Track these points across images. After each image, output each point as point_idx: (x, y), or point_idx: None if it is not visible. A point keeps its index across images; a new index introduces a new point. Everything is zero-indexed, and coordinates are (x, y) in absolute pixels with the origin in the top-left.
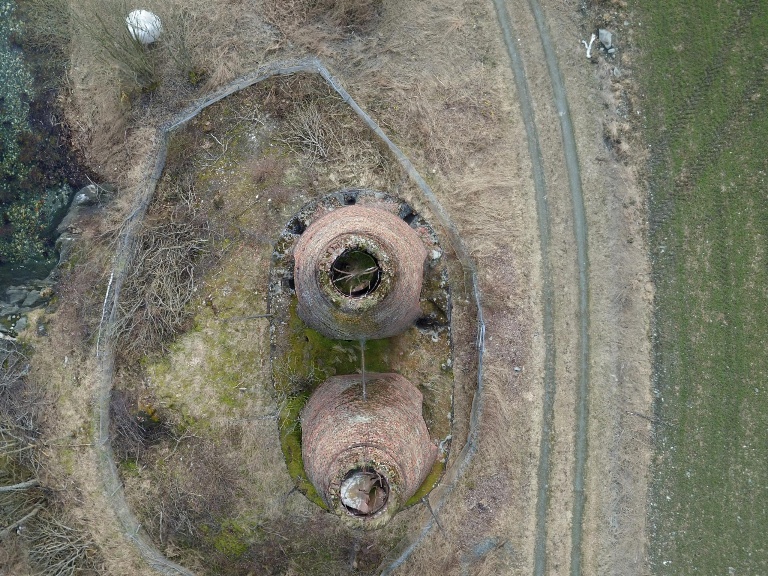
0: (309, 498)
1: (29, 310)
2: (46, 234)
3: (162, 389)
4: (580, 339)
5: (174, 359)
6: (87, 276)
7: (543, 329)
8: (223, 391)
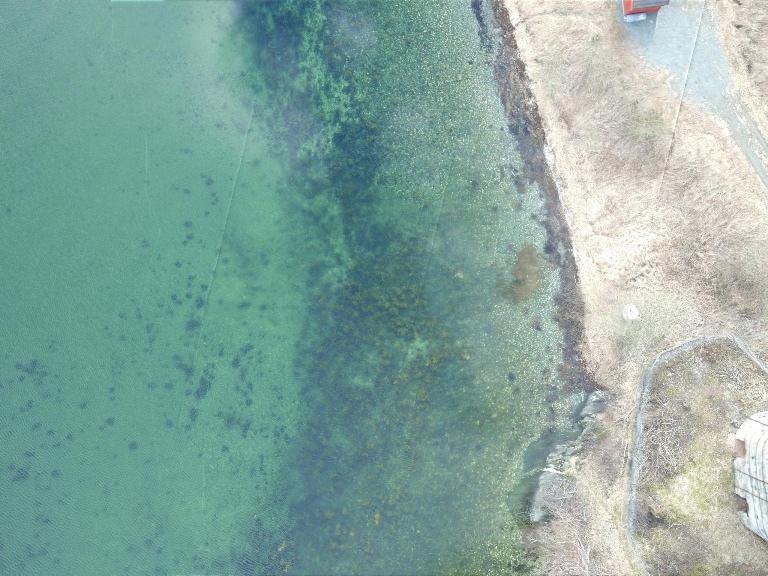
0: None
1: (570, 458)
2: (573, 417)
3: (668, 502)
4: None
5: (672, 487)
6: (615, 444)
7: None
8: (699, 502)
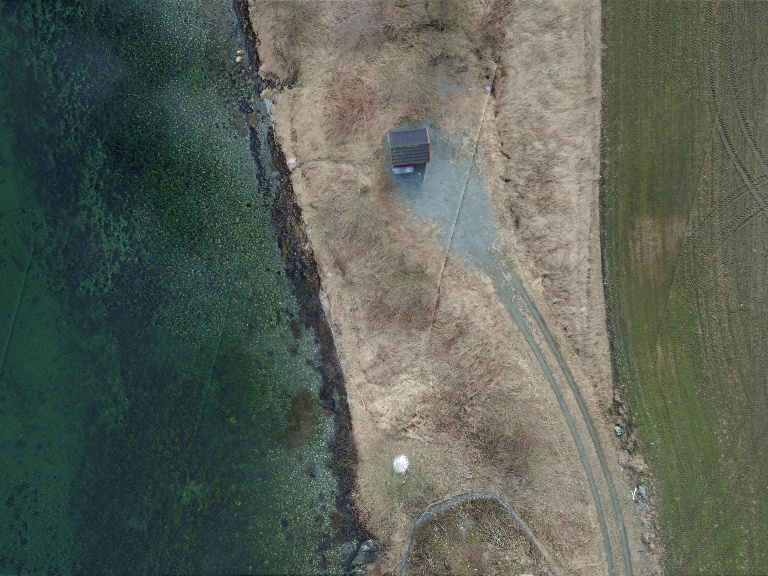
0: None
1: None
2: (345, 565)
3: None
4: None
5: None
6: None
7: None
8: None
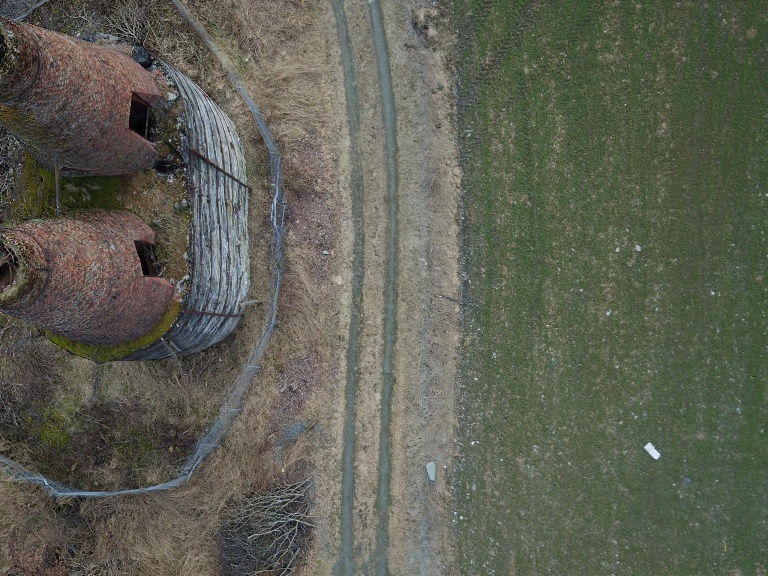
0: None
1: None
2: None
3: None
4: (389, 223)
5: None
6: None
7: (352, 214)
8: None
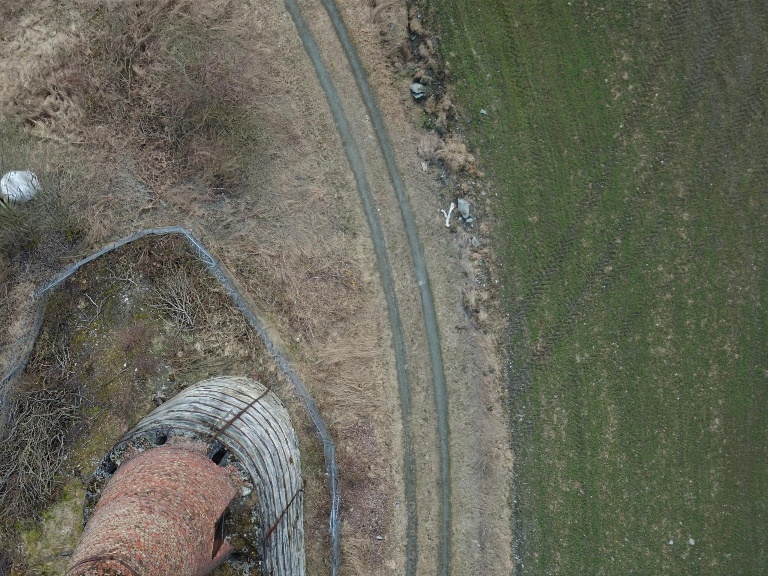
0: None
1: None
2: None
3: (34, 557)
4: (442, 506)
5: (45, 527)
6: None
7: (405, 497)
8: None
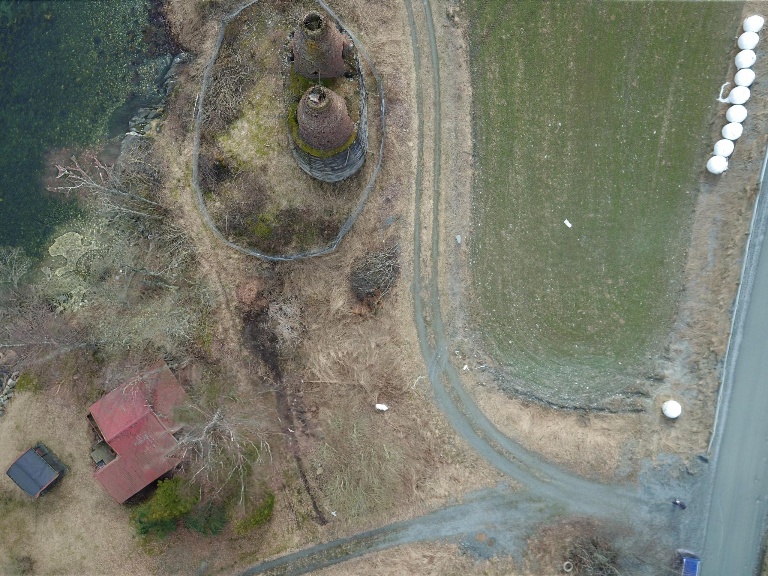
0: (301, 148)
1: (151, 120)
2: (159, 81)
3: (227, 147)
4: (436, 115)
5: (233, 132)
6: (185, 96)
7: (417, 111)
8: (258, 147)
